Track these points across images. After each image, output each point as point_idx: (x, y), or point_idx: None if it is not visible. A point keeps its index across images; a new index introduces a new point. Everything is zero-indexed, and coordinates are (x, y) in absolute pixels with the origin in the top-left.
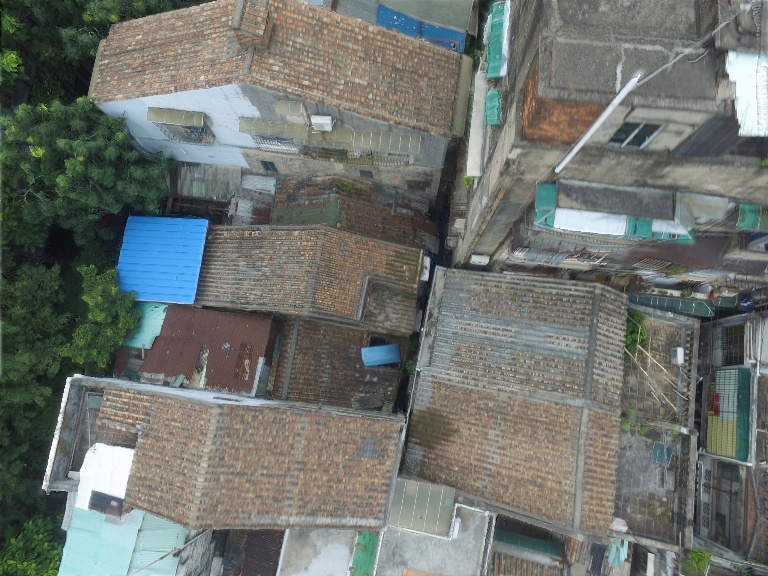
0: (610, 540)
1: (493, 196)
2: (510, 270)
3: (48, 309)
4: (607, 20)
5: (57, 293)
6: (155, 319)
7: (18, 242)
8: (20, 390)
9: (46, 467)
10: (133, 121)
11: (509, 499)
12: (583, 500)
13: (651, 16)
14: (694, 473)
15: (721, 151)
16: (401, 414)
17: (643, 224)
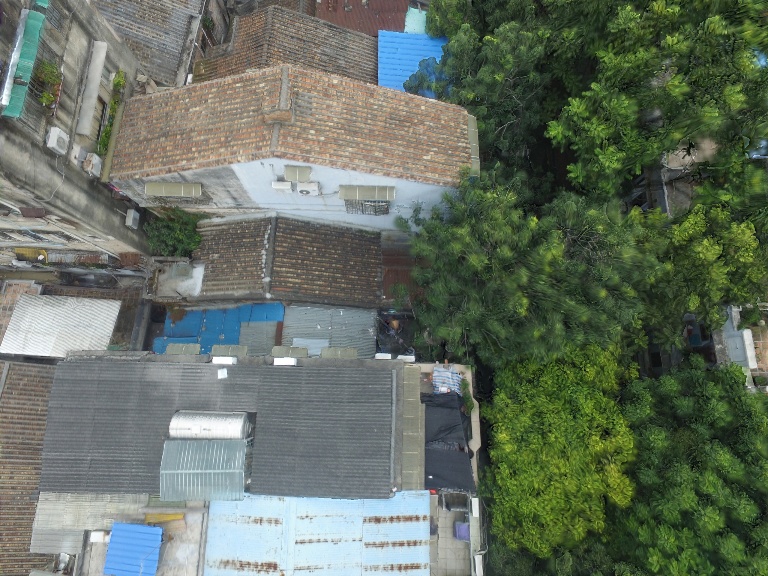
0: None
1: None
2: None
3: (498, 16)
4: None
5: None
6: (414, 29)
7: None
8: None
9: None
10: None
11: None
12: None
13: None
14: None
15: None
16: (221, 3)
17: None
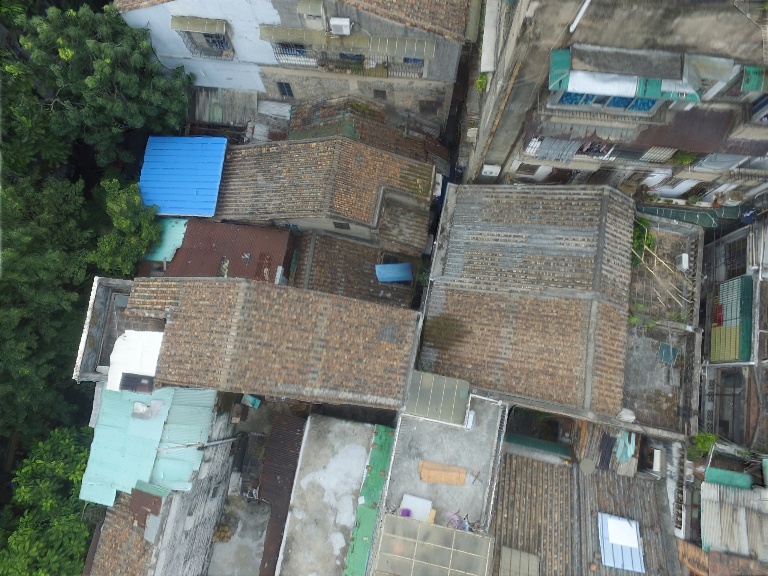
0: (618, 435)
1: (508, 75)
2: (520, 182)
3: (73, 221)
4: None
5: (80, 211)
6: (176, 233)
7: (44, 156)
8: (48, 293)
9: (69, 384)
10: (156, 35)
11: (521, 389)
12: (593, 384)
13: None
14: (699, 367)
15: None
16: None
17: (653, 84)
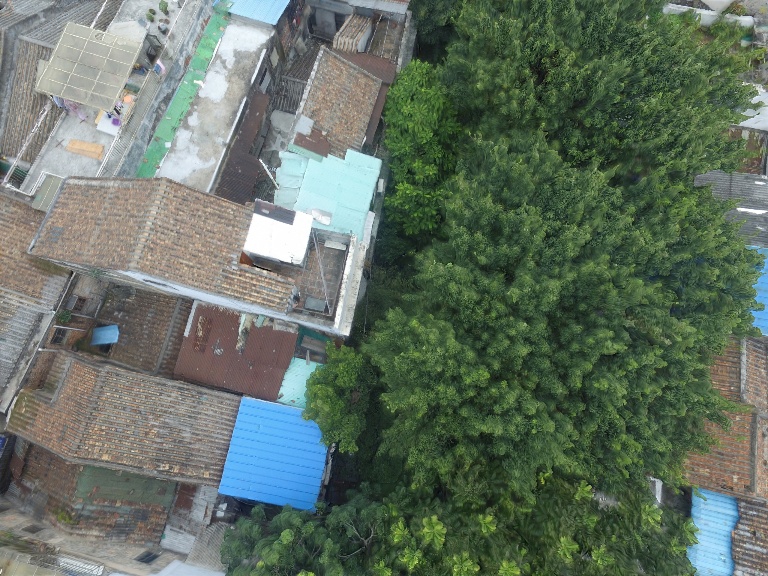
0: None
1: None
2: None
3: None
4: None
5: None
6: (293, 388)
7: None
8: None
9: None
10: None
11: None
12: None
13: None
14: None
15: None
16: None
17: None
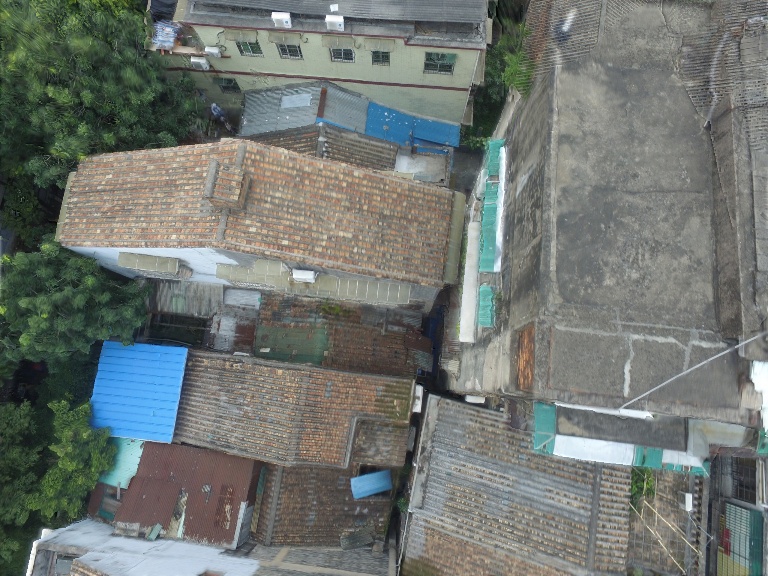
0: None
1: None
2: None
3: (17, 450)
4: (613, 296)
5: None
6: (131, 455)
7: None
8: None
9: None
10: (105, 257)
11: None
12: None
13: (663, 293)
14: None
15: None
16: (393, 552)
17: (652, 455)
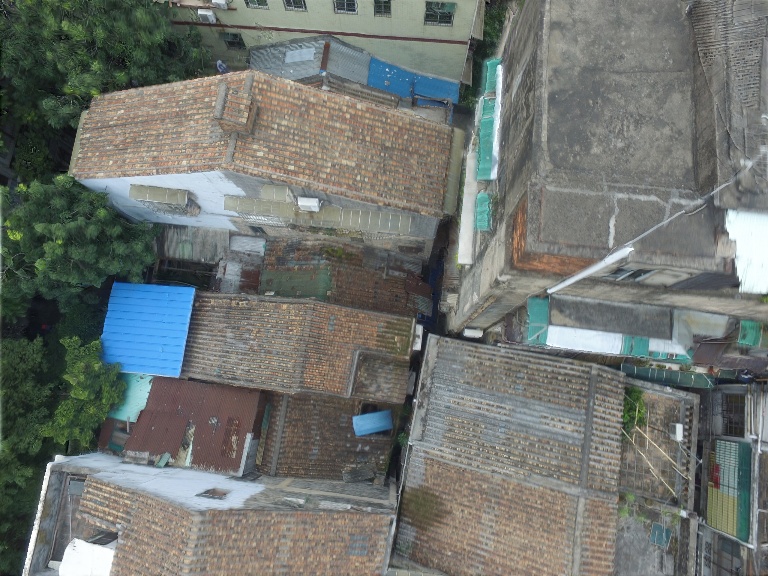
0: None
1: (484, 298)
2: (504, 342)
3: (30, 383)
4: (600, 163)
5: (40, 362)
6: (140, 391)
7: None
8: None
9: None
10: (116, 193)
11: None
12: None
13: (646, 159)
14: (694, 560)
15: (721, 287)
16: (393, 486)
17: (639, 343)
